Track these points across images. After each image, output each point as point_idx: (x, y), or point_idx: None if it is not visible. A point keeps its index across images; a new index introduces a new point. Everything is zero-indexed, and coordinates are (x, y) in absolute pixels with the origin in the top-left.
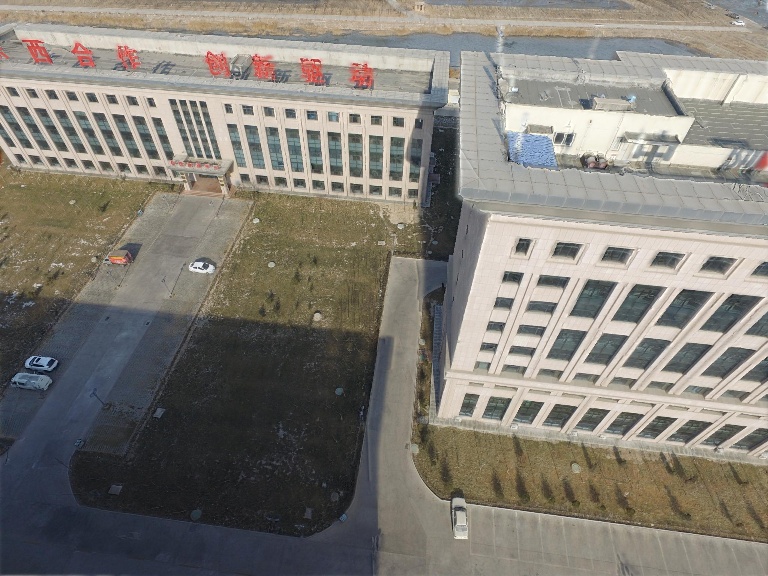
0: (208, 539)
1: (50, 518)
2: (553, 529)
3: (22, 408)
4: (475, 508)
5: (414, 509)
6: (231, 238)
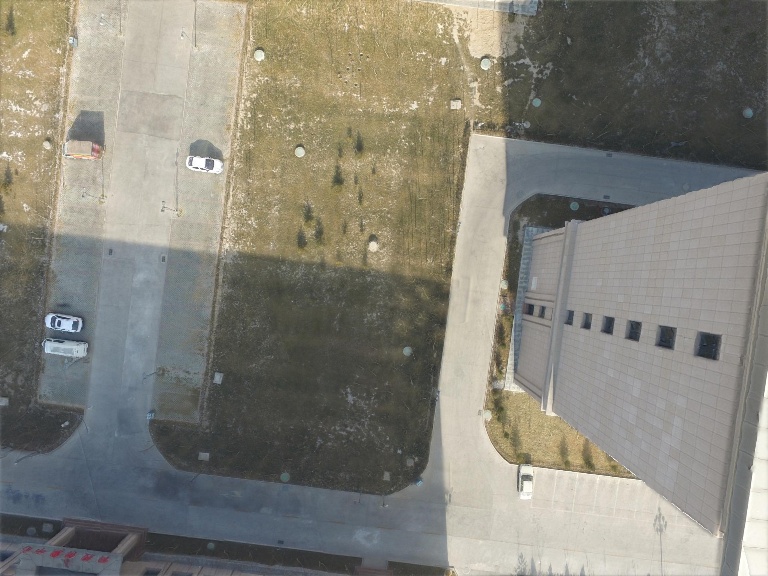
0: (301, 497)
1: (155, 480)
2: (608, 488)
3: (72, 374)
4: (540, 471)
5: (484, 472)
6: (230, 97)
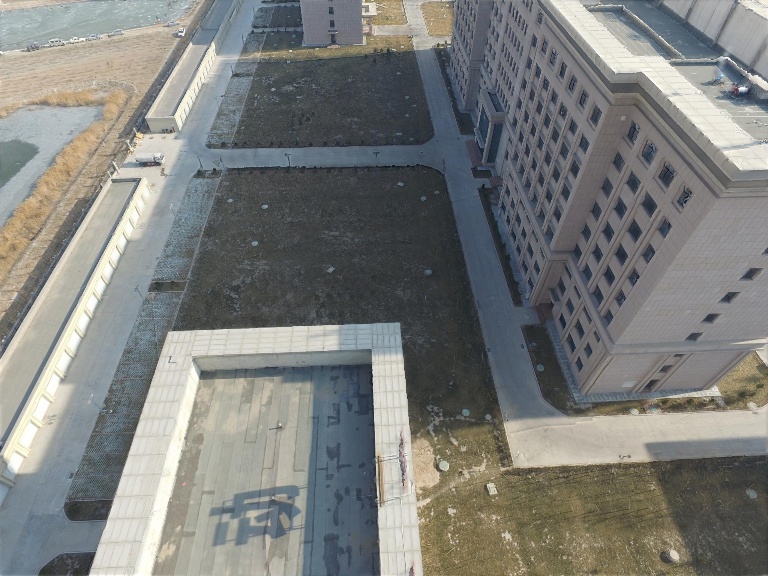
0: None
1: None
2: None
3: None
4: (762, 357)
5: None
6: None
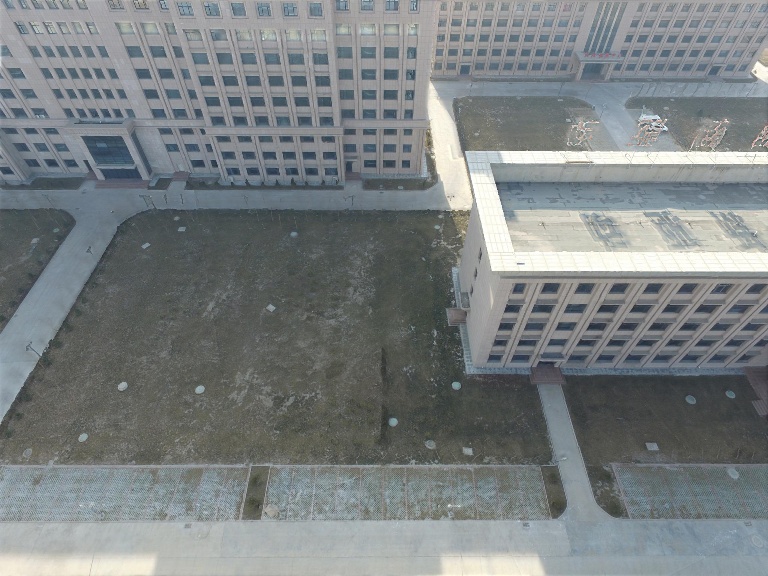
0: None
1: None
2: None
3: None
4: None
5: None
6: None
